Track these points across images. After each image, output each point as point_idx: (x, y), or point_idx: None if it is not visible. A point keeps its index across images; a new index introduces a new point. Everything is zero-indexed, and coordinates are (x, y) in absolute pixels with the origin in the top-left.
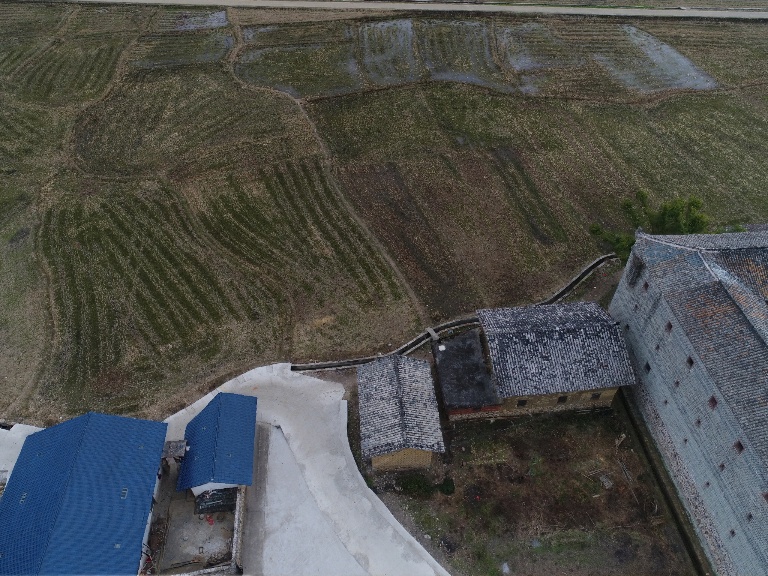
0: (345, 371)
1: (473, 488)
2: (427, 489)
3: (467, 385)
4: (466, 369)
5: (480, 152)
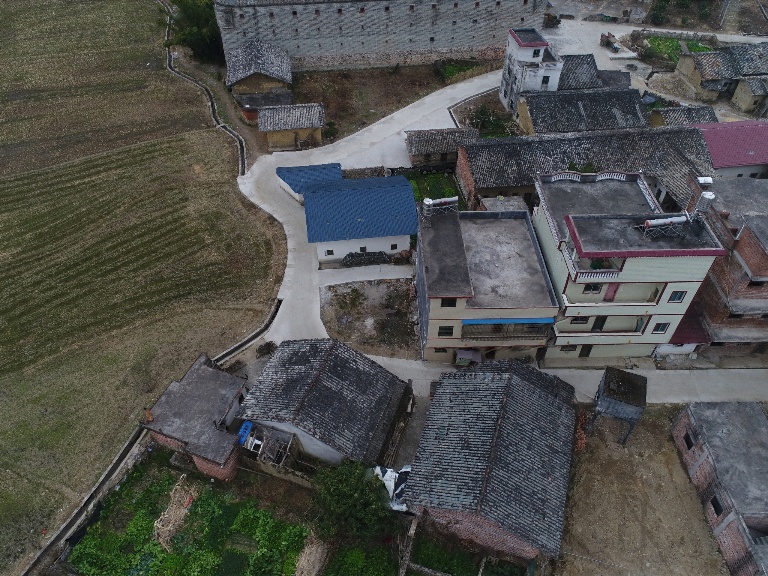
0: (248, 156)
1: (332, 117)
2: (333, 128)
3: (277, 99)
4: (265, 99)
5: (7, 106)
